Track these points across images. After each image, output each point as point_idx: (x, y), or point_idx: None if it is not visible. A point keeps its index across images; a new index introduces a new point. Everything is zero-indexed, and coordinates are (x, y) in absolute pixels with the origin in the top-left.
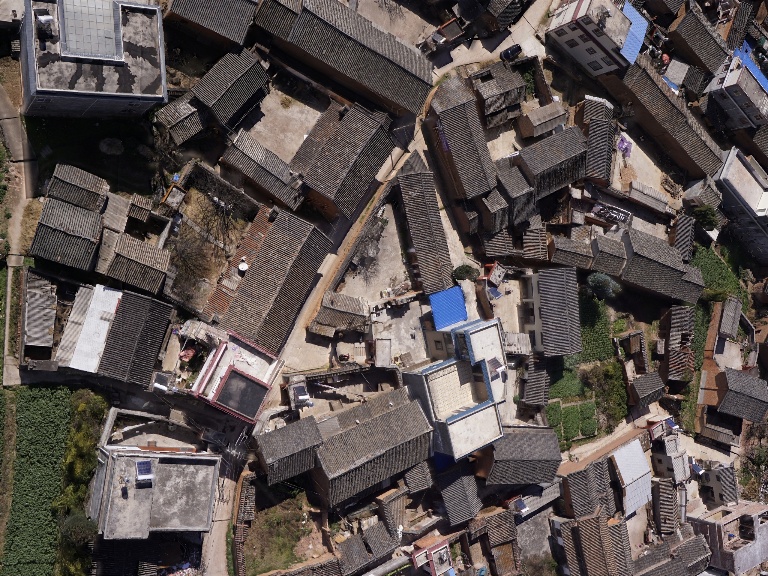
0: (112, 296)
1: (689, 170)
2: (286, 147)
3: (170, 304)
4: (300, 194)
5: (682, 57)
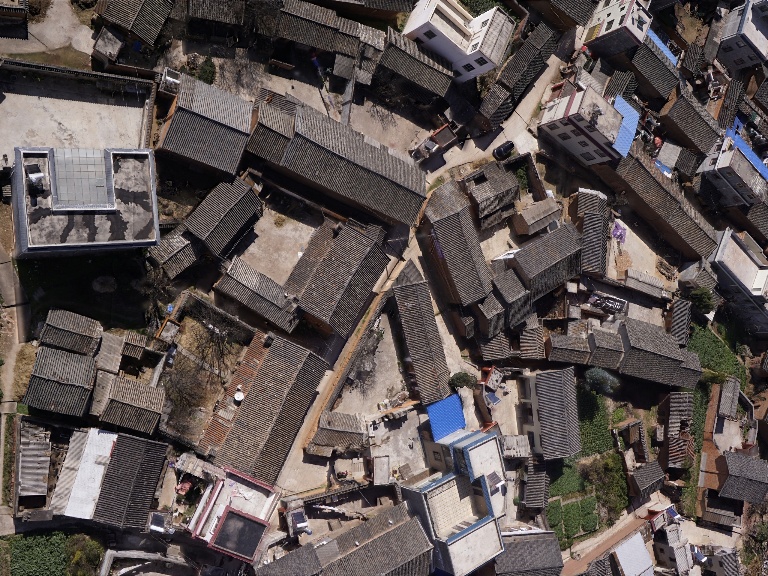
0: (107, 439)
1: (684, 251)
2: (280, 266)
3: (166, 440)
4: (295, 317)
5: (674, 139)
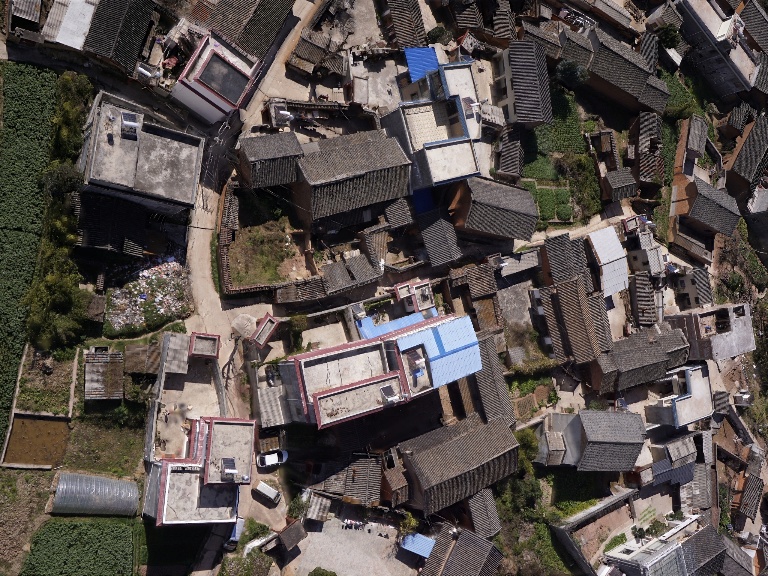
0: None
1: None
2: None
3: None
4: None
5: None
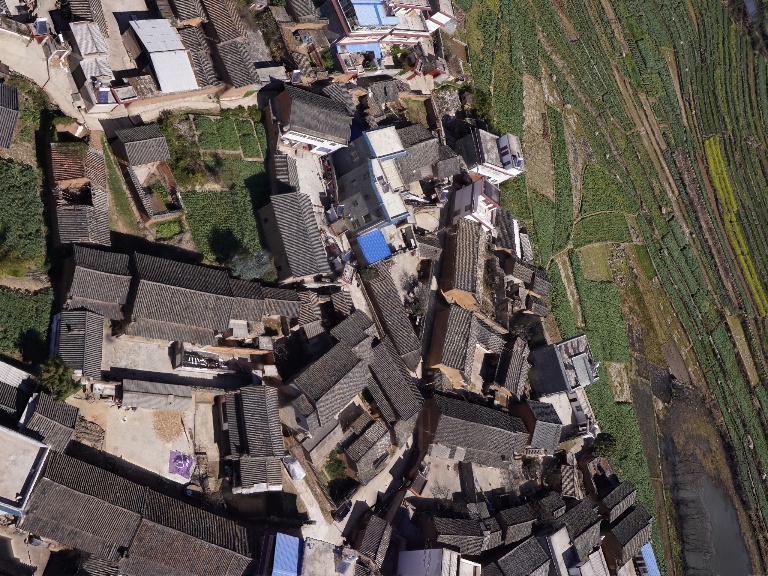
0: None
1: None
2: None
3: None
4: None
5: None
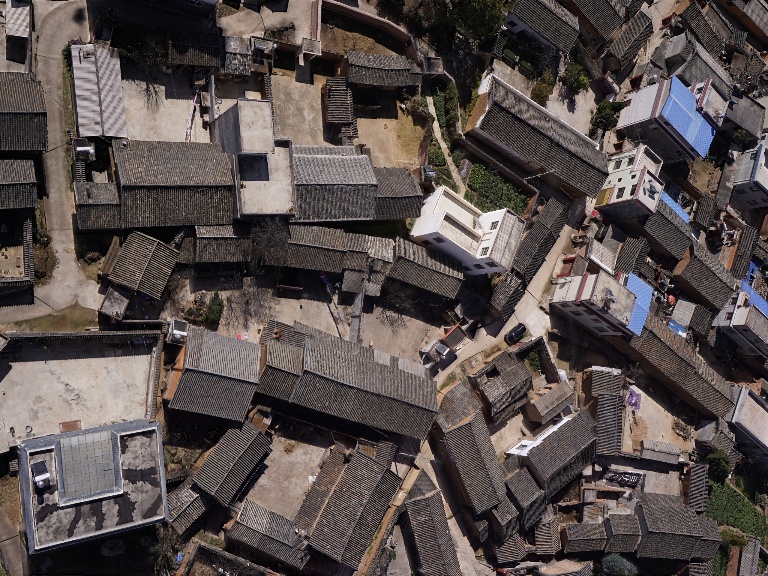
0: None
1: (700, 410)
2: (291, 494)
3: None
4: (306, 553)
5: (688, 295)
